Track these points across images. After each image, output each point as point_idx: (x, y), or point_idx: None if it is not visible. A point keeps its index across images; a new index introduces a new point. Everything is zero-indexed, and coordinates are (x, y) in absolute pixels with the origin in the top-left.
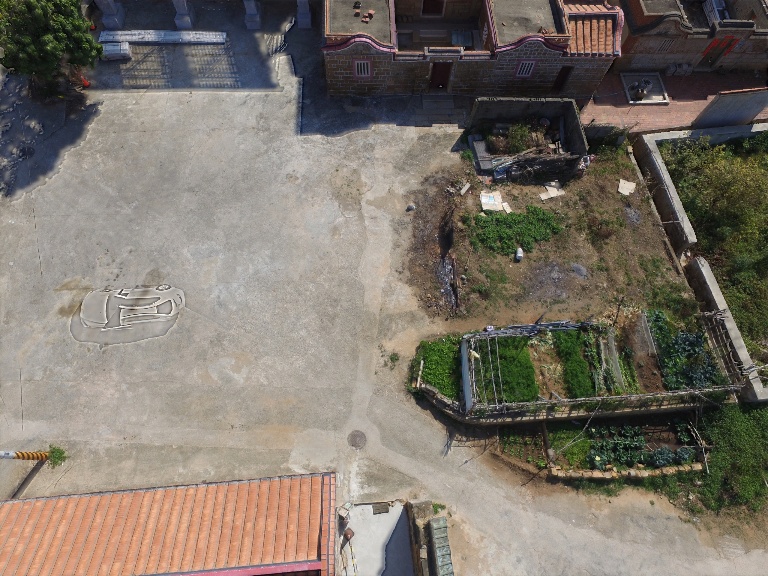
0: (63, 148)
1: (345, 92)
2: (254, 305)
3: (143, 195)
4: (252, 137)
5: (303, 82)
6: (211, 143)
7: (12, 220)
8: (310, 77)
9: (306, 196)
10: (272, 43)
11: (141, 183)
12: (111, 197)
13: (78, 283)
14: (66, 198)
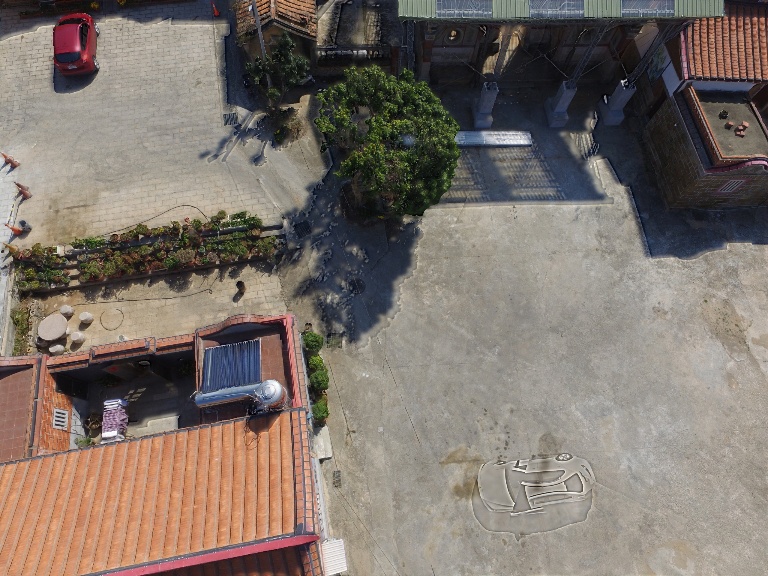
0: (395, 279)
1: (688, 205)
2: (672, 477)
3: (503, 337)
4: (599, 261)
5: (632, 191)
6: (557, 270)
7: (366, 373)
8: (637, 185)
9: (683, 334)
10: (582, 144)
11: (496, 322)
12: (468, 341)
13: (465, 453)
14: (418, 343)
